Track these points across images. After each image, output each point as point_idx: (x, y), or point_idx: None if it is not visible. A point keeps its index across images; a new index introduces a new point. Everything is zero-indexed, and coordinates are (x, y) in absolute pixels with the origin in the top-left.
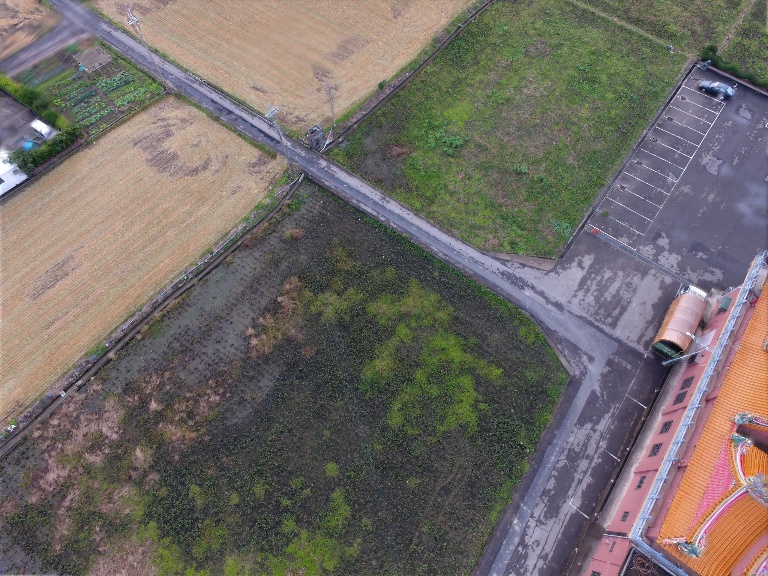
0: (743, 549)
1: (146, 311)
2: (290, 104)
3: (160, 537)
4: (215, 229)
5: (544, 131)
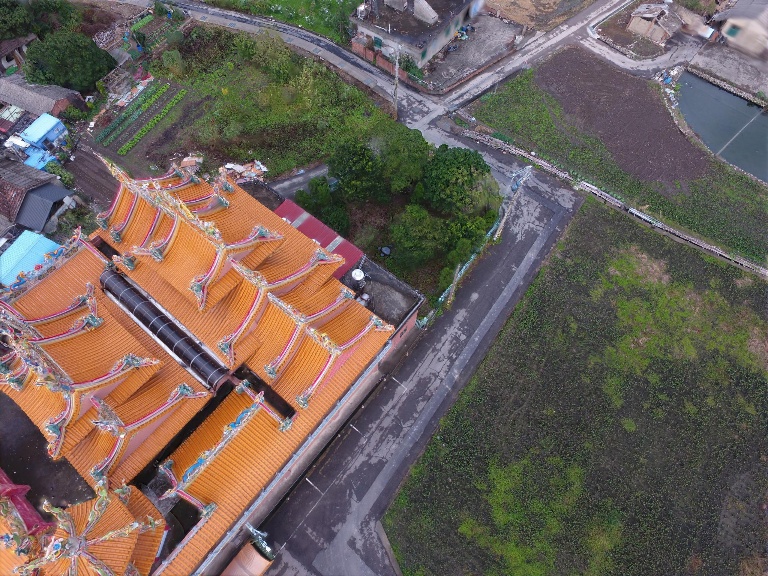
0: (335, 319)
1: None
2: None
3: (761, 373)
4: None
5: None
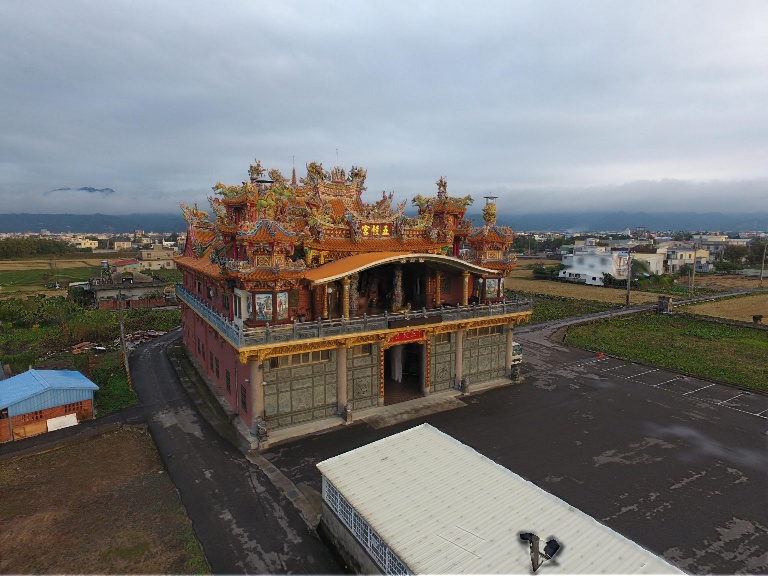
0: None
1: (526, 292)
2: (707, 310)
3: None
4: (577, 297)
5: (763, 363)
